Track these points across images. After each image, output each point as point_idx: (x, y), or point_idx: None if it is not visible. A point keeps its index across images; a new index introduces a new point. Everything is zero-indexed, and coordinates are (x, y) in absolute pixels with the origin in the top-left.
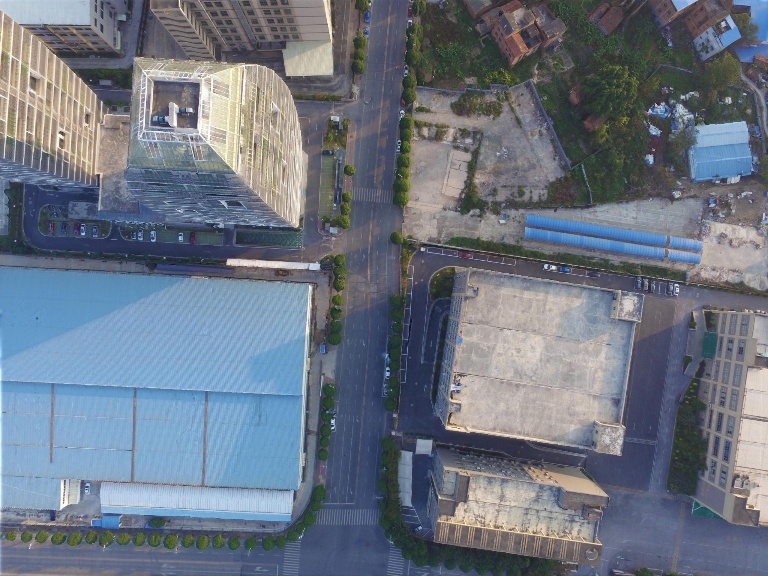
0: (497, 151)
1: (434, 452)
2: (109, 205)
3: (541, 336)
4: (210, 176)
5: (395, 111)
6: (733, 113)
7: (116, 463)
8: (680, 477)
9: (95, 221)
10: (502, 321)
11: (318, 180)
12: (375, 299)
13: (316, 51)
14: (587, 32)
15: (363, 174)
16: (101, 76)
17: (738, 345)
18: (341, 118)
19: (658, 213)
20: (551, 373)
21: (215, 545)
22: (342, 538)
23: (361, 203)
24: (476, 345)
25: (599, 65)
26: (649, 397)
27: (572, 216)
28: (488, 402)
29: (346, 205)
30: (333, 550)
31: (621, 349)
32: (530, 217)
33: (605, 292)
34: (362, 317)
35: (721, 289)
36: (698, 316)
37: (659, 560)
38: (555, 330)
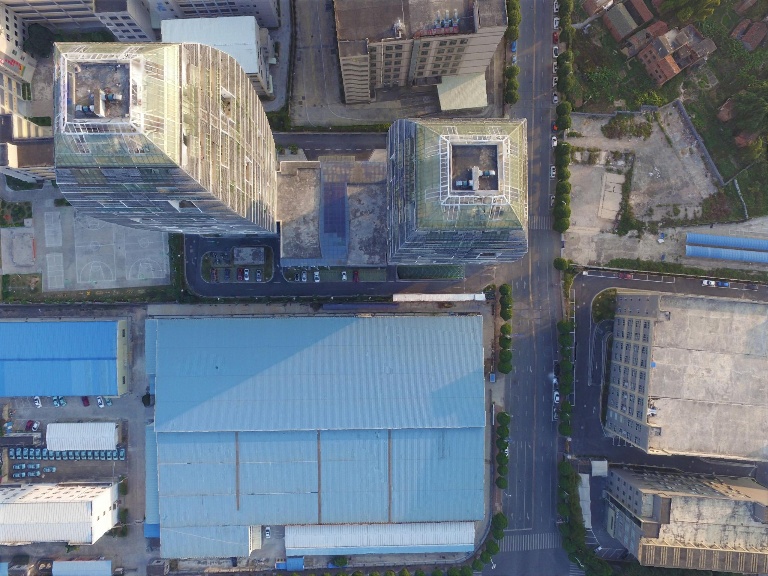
0: (650, 171)
1: (608, 472)
2: (290, 251)
3: (729, 355)
4: (494, 233)
5: (546, 138)
6: None
7: (303, 506)
8: None
9: (257, 265)
10: (691, 343)
11: None
12: (539, 325)
13: (470, 83)
14: (732, 49)
15: None
16: None
17: None
18: None
19: None
20: (742, 391)
21: None
22: (522, 564)
23: None
24: (667, 368)
25: (747, 81)
26: None
27: (728, 231)
28: (682, 423)
29: None
30: None
31: None
32: (690, 235)
33: None
34: (527, 344)
35: None
36: None
37: None
38: (743, 348)
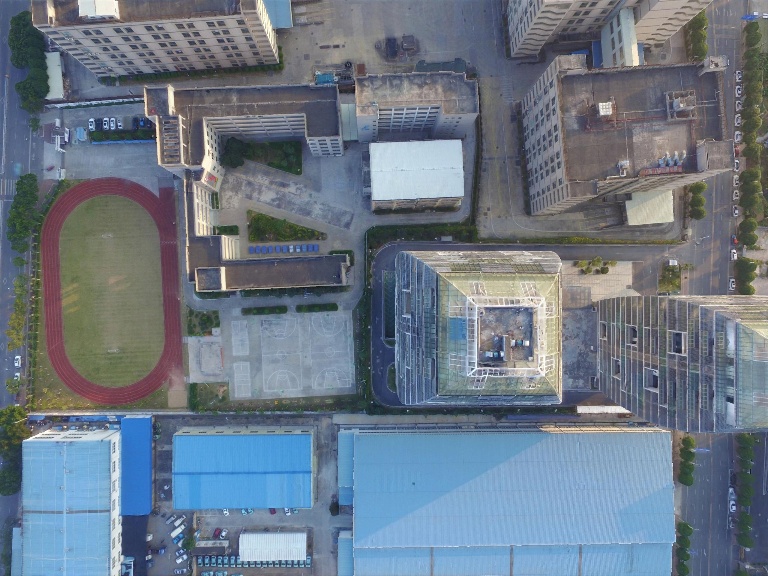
0: None
1: None
2: None
3: None
4: None
5: (725, 250)
6: None
7: None
8: None
9: None
10: None
11: None
12: (716, 435)
13: (657, 199)
14: None
15: None
16: (447, 234)
17: None
18: (677, 261)
19: None
20: None
21: None
22: None
23: None
24: None
25: None
26: None
27: None
28: None
29: None
30: None
31: None
32: None
33: None
34: (704, 453)
35: None
36: None
37: None
38: None
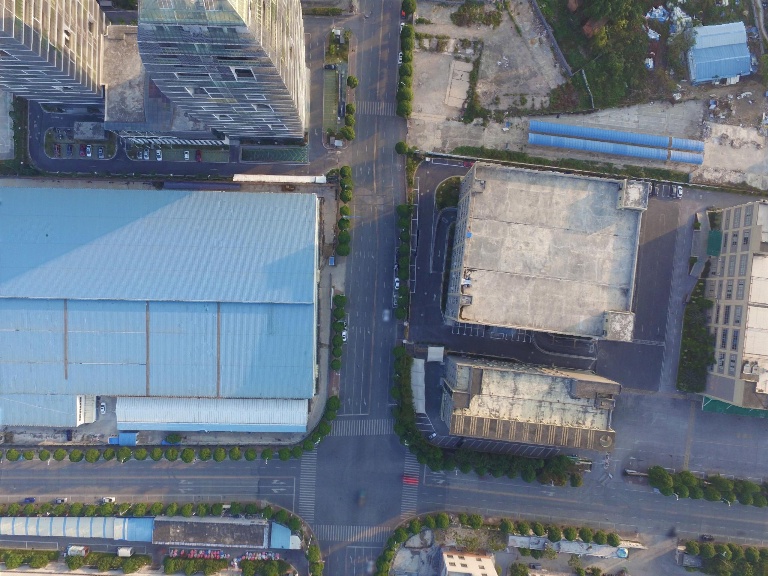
0: (498, 60)
1: (446, 360)
2: (115, 116)
3: (549, 229)
4: (221, 31)
5: (395, 24)
6: (730, 15)
7: (131, 377)
8: (689, 374)
9: (101, 142)
10: (510, 215)
11: (321, 95)
12: (382, 211)
13: None
14: None
15: (366, 87)
16: None
17: (743, 236)
18: (342, 32)
19: (659, 116)
20: (560, 265)
21: (232, 456)
22: (357, 448)
23: (365, 116)
24: (485, 240)
25: None
26: (656, 299)
27: (574, 122)
28: (498, 296)
29: (350, 116)
30: (349, 461)
31: (628, 239)
32: (533, 123)
33: (610, 184)
34: (370, 229)
35: (724, 190)
36: (702, 217)
37: (671, 459)
38: (562, 223)
